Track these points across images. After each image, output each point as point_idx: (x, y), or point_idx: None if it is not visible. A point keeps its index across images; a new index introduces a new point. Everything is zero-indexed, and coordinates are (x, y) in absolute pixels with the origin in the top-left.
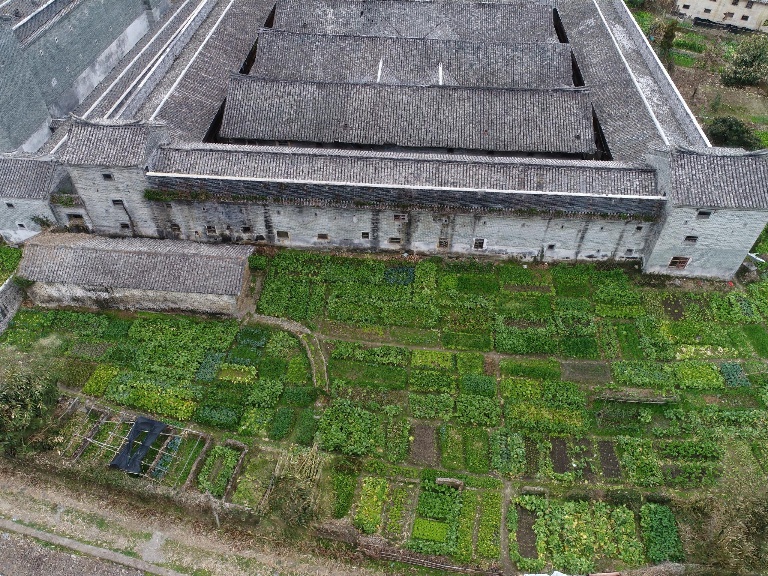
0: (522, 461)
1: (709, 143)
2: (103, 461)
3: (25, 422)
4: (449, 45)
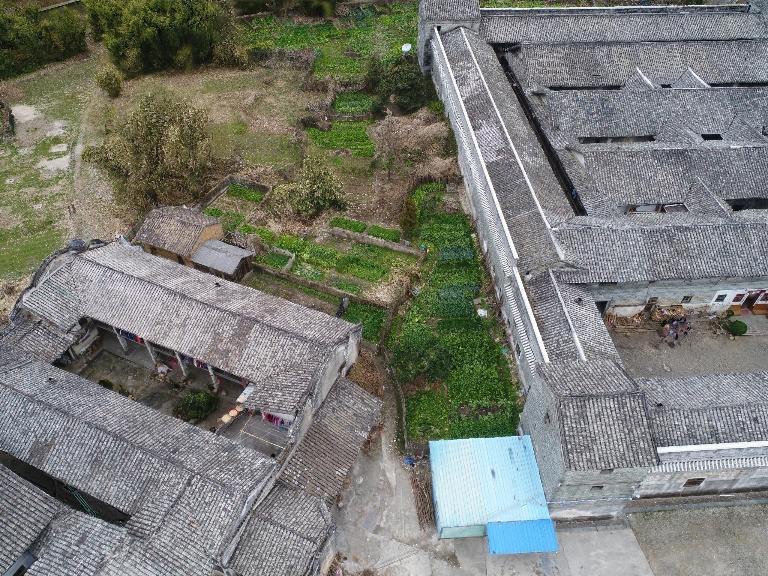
0: None
1: (438, 34)
2: (653, 1)
3: None
4: None
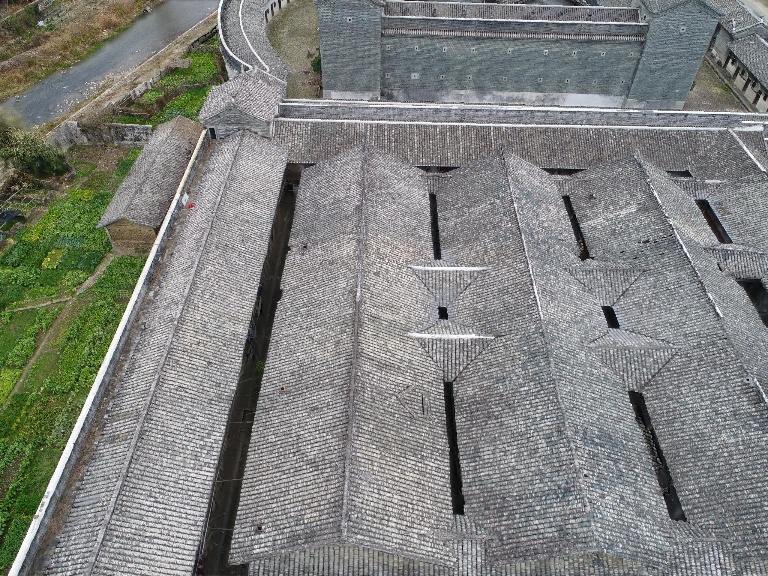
0: None
1: None
2: None
3: (1, 153)
4: (534, 337)
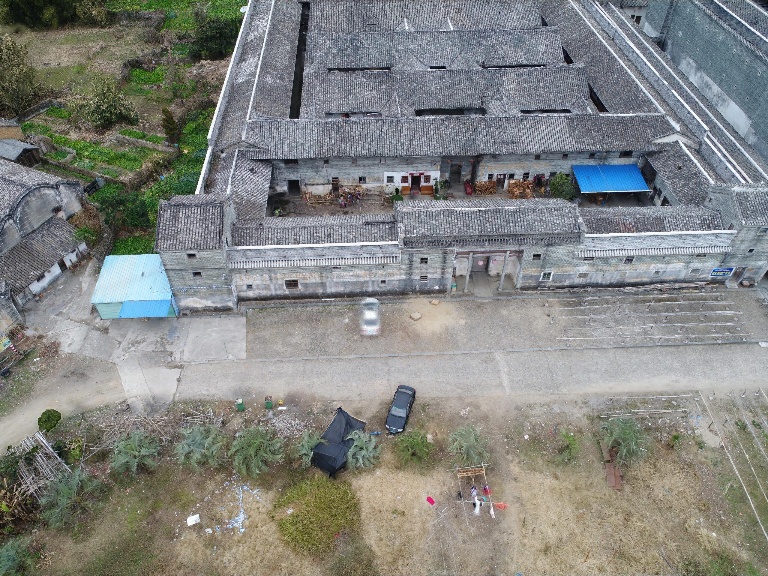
0: None
1: None
2: None
3: None
4: None
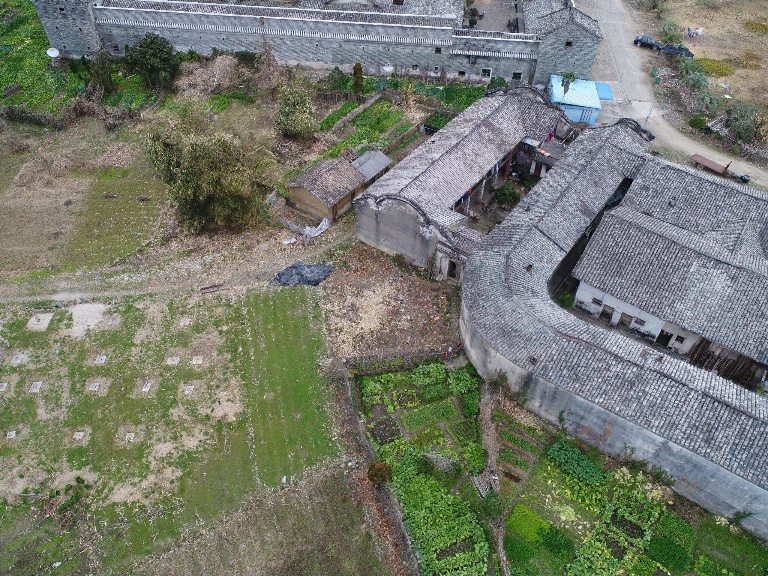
0: (17, 4)
1: (113, 7)
2: None
3: None
4: None
